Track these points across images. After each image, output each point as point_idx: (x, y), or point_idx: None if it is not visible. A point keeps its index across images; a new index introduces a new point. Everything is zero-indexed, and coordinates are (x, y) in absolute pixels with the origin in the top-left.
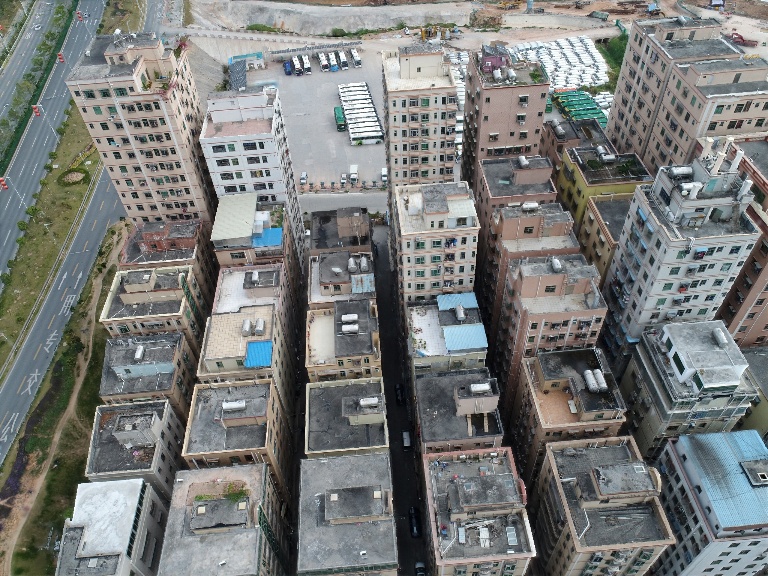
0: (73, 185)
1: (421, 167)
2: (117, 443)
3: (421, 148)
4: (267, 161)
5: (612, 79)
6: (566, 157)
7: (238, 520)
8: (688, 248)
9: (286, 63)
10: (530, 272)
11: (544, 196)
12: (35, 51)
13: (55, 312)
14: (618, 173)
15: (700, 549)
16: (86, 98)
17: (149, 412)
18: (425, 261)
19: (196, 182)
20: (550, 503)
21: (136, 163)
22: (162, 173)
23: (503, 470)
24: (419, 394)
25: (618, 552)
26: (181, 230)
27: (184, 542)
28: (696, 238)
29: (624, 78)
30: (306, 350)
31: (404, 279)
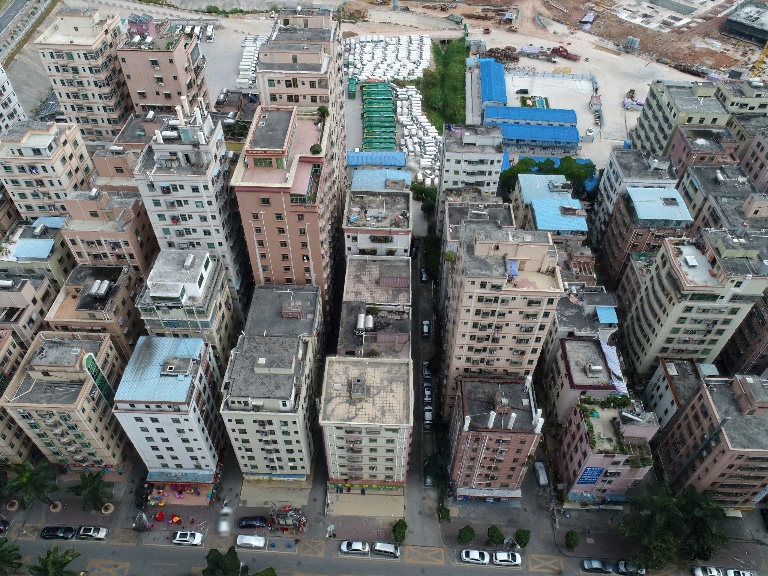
0: None
1: (89, 115)
2: None
3: (82, 98)
4: None
5: (427, 76)
6: None
7: None
8: (151, 182)
9: None
10: (73, 197)
11: None
12: None
13: None
14: None
15: None
16: None
17: None
18: (21, 184)
19: None
20: None
21: None
22: None
23: None
24: None
25: (37, 411)
26: None
27: None
28: (152, 174)
29: None
30: None
31: None
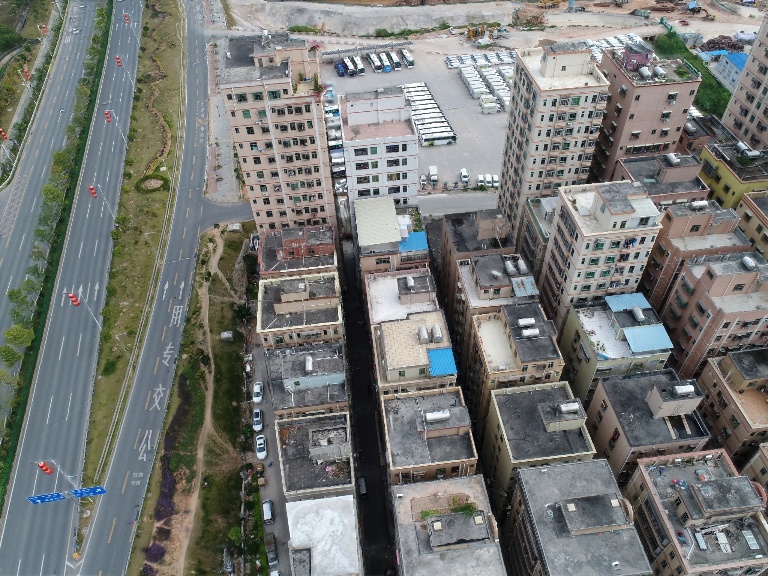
0: (153, 192)
1: (558, 167)
2: (305, 459)
3: (562, 148)
4: (406, 163)
5: None
6: (707, 154)
7: (479, 535)
8: None
9: (338, 64)
10: (722, 271)
11: (697, 194)
12: (79, 55)
13: (165, 324)
14: None
15: None
16: (237, 101)
17: (341, 425)
18: (598, 262)
19: (331, 186)
20: (767, 504)
21: (274, 168)
22: (299, 178)
23: (720, 472)
24: None
25: None
26: (318, 236)
27: (424, 560)
28: None
29: (750, 74)
30: (484, 356)
31: (572, 281)
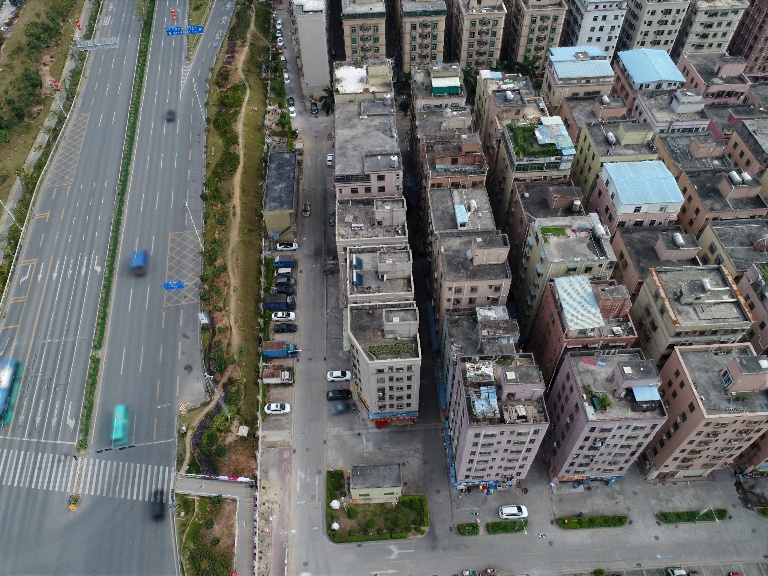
0: None
1: None
2: None
3: None
4: None
5: None
6: None
7: None
8: None
9: None
10: None
11: None
12: None
13: None
14: None
15: (581, 25)
16: None
17: None
18: None
19: None
20: None
21: None
22: None
23: None
24: None
25: (543, 15)
26: None
27: (351, 6)
28: None
29: None
30: None
31: None
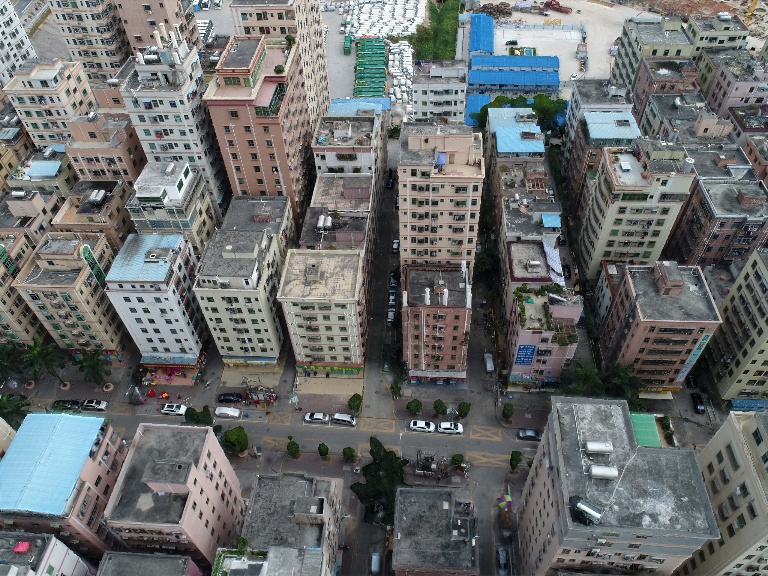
0: None
1: (94, 60)
2: None
3: (87, 43)
4: None
5: (420, 32)
6: None
7: None
8: (135, 99)
9: None
10: (74, 120)
11: None
12: None
13: None
14: (205, 68)
15: None
16: None
17: None
18: (33, 115)
19: None
20: None
21: None
22: None
23: None
24: (1, 203)
25: (43, 292)
26: None
27: None
28: None
29: None
30: None
31: None
